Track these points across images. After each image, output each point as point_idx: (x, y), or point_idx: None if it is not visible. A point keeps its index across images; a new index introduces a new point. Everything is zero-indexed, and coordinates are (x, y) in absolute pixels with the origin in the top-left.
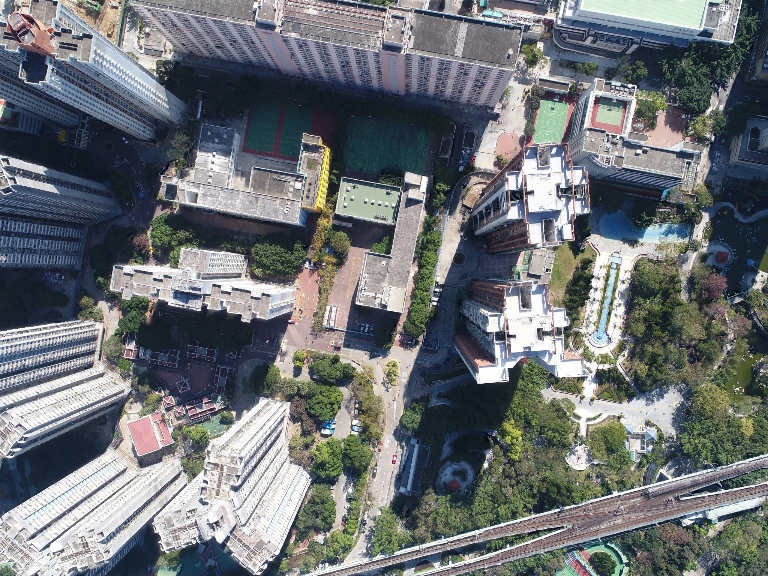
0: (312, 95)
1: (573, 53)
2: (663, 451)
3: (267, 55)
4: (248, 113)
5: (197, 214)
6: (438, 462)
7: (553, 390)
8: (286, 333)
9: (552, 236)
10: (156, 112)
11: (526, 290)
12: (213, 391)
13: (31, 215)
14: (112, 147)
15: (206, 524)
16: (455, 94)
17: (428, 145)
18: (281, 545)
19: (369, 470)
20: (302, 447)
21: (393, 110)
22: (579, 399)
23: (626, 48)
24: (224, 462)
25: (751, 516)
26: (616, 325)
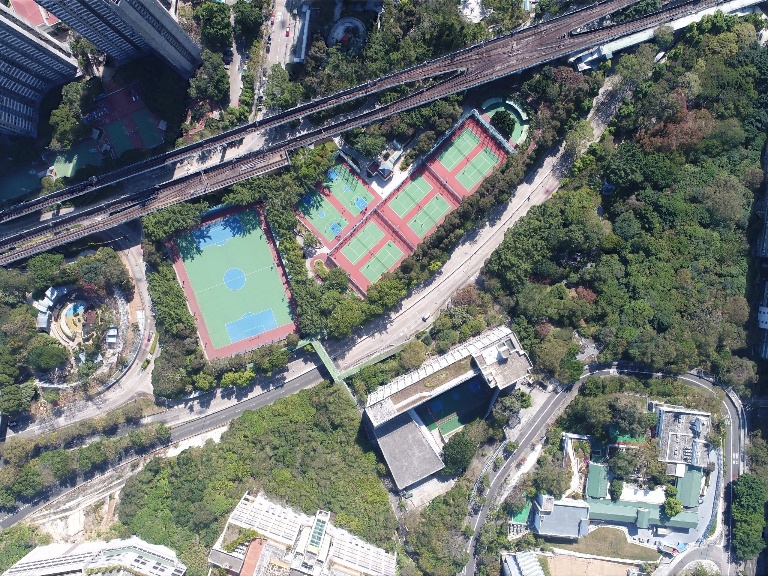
0: None
1: None
2: None
3: None
4: None
5: None
6: (326, 7)
7: None
8: None
9: None
10: None
11: None
12: None
13: None
14: None
15: None
16: None
17: None
18: None
19: (263, 45)
20: None
21: None
22: None
23: None
24: None
25: (645, 46)
26: None
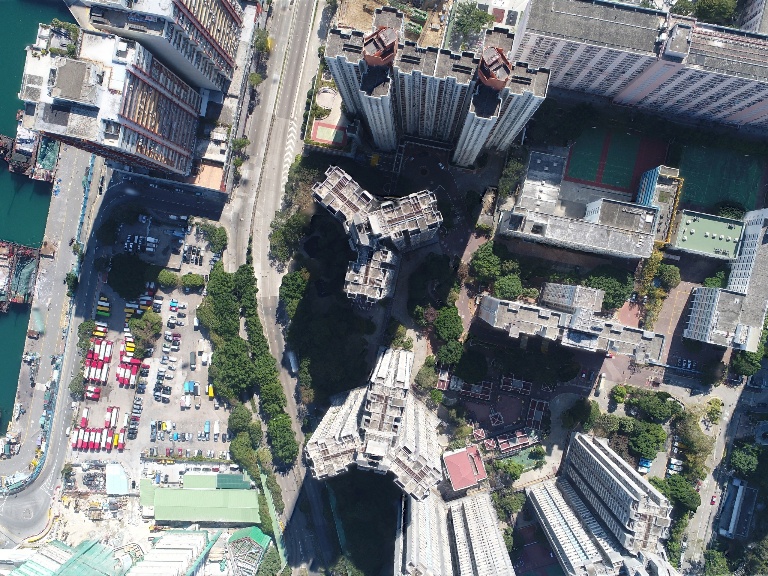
0: None
1: None
2: None
3: (619, 84)
4: (571, 140)
5: (513, 243)
6: None
7: None
8: (602, 367)
9: None
10: None
11: None
12: (526, 425)
13: (396, 246)
14: (427, 172)
15: None
16: None
17: (760, 177)
18: None
19: None
20: None
21: (734, 141)
22: None
23: None
24: (652, 513)
25: None
26: None
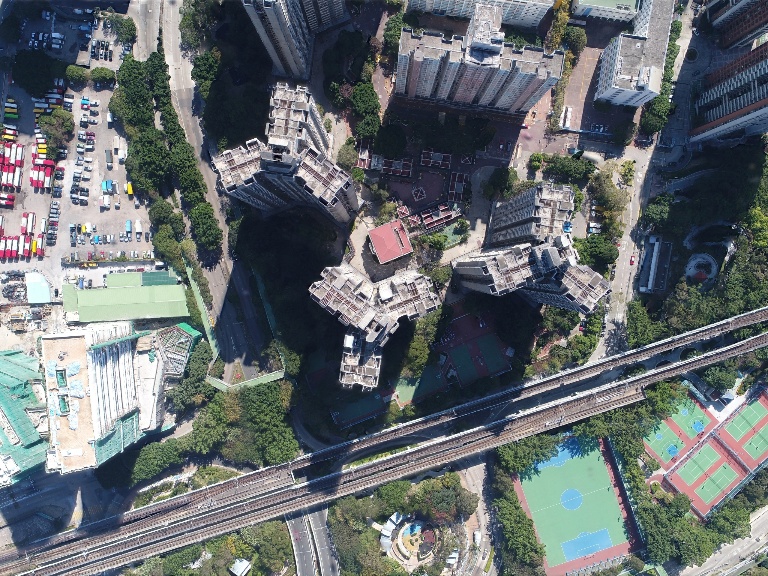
0: None
1: None
2: None
3: None
4: None
5: (425, 19)
6: (690, 250)
7: None
8: (519, 138)
9: None
10: None
11: None
12: (449, 198)
13: None
14: None
15: None
16: None
17: None
18: None
19: None
20: None
21: None
22: None
23: None
24: (556, 198)
25: None
26: None
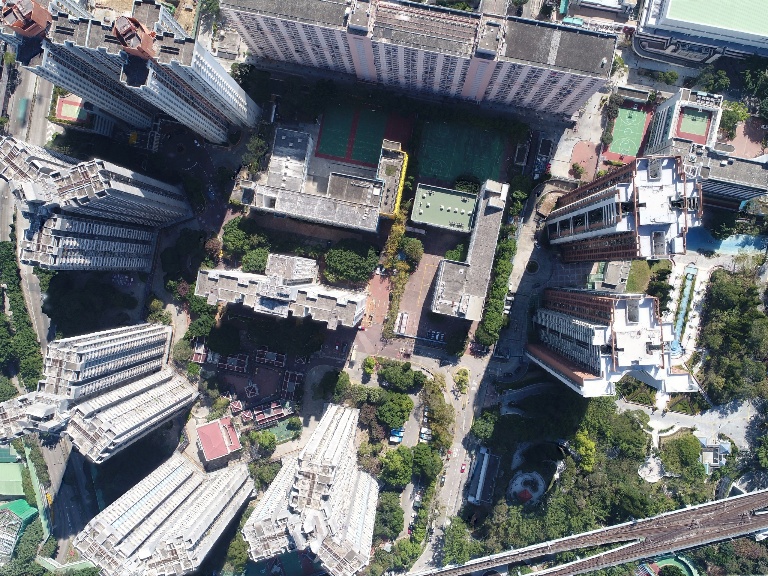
0: (388, 100)
1: (652, 61)
2: (737, 465)
3: (347, 60)
4: (321, 117)
5: (268, 218)
6: (511, 472)
7: (625, 401)
8: (355, 339)
9: (660, 249)
10: (233, 116)
11: (630, 303)
12: (281, 396)
13: (113, 218)
14: (184, 150)
15: (300, 534)
16: (534, 101)
17: (503, 152)
18: (369, 555)
19: (437, 479)
20: (370, 454)
21: (470, 117)
22: (651, 411)
23: (707, 57)
24: (316, 471)
25: None
26: (691, 336)
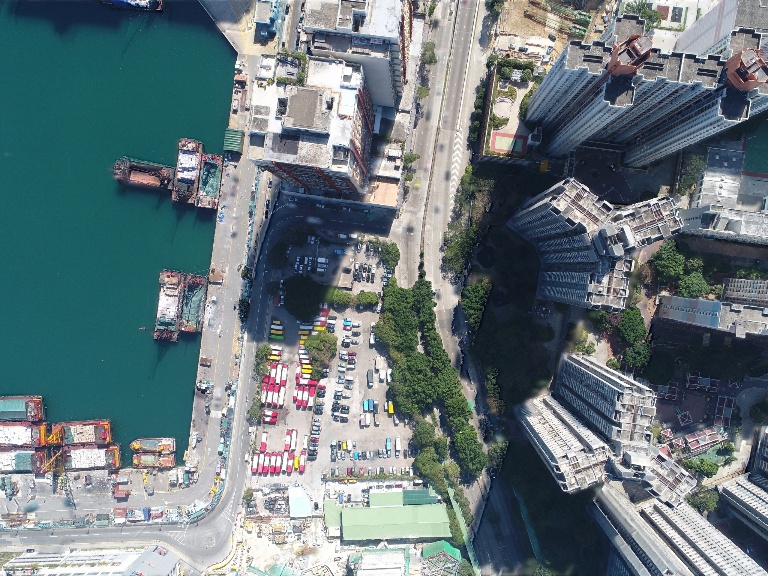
0: None
1: None
2: None
3: None
4: (744, 134)
5: (690, 240)
6: None
7: None
8: None
9: None
10: None
11: None
12: (715, 422)
13: None
14: (598, 175)
15: None
16: None
17: None
18: None
19: None
20: None
21: None
22: None
23: None
24: None
25: None
26: None
